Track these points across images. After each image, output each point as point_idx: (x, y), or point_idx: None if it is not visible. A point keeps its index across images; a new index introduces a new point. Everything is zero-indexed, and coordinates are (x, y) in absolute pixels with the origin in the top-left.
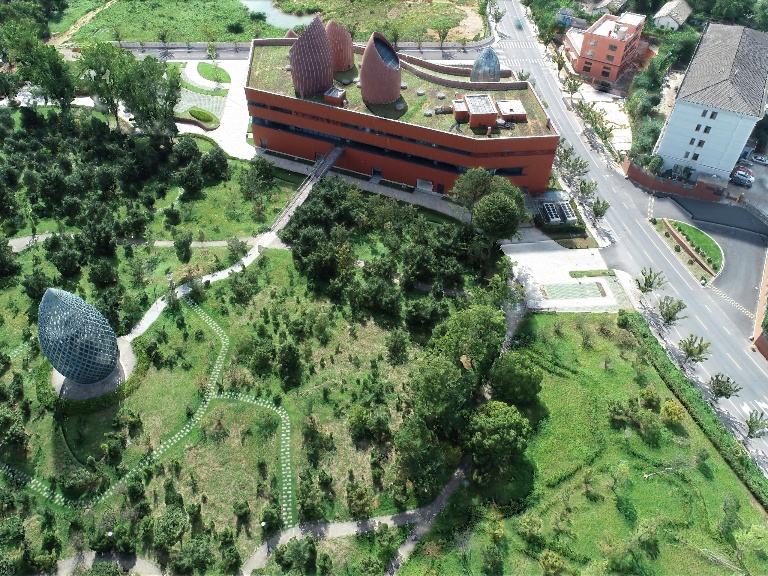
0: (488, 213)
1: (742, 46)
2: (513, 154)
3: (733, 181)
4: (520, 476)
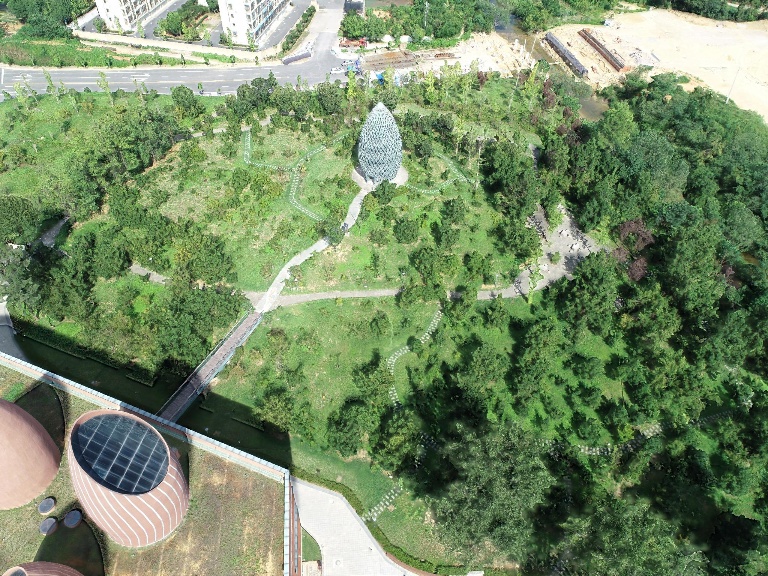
0: (22, 200)
1: None
2: None
3: None
4: None
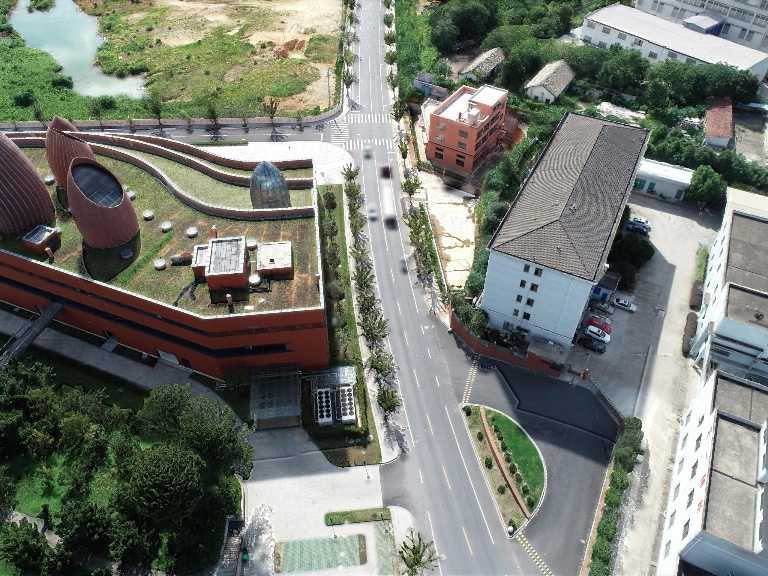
0: (140, 490)
1: (593, 158)
2: (264, 330)
3: (581, 342)
4: None
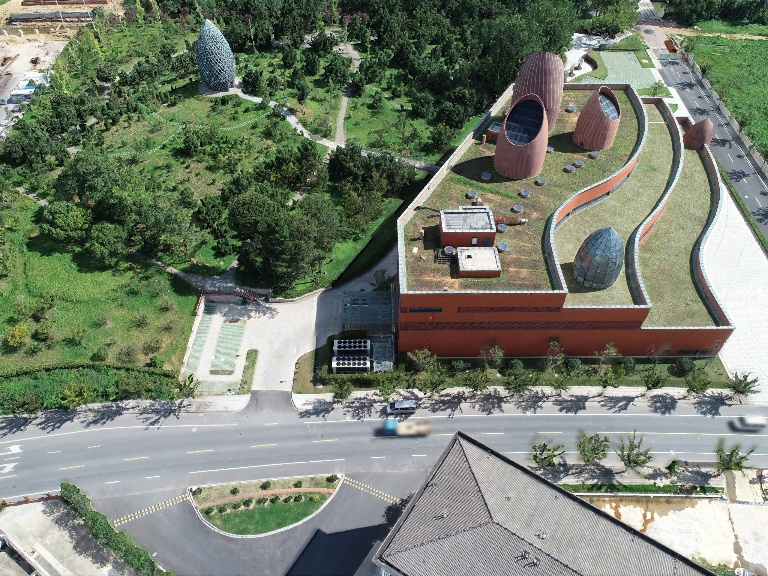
0: None
1: None
2: None
3: None
4: (43, 247)
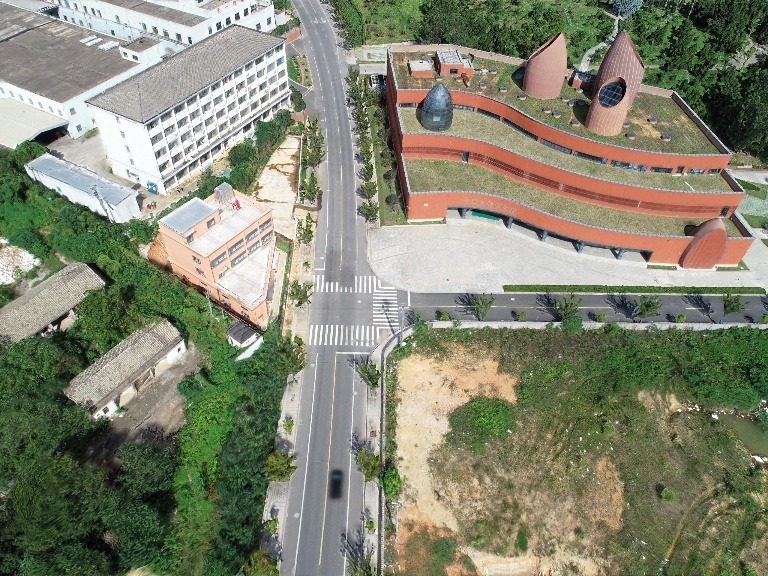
0: None
1: None
2: None
3: None
4: None
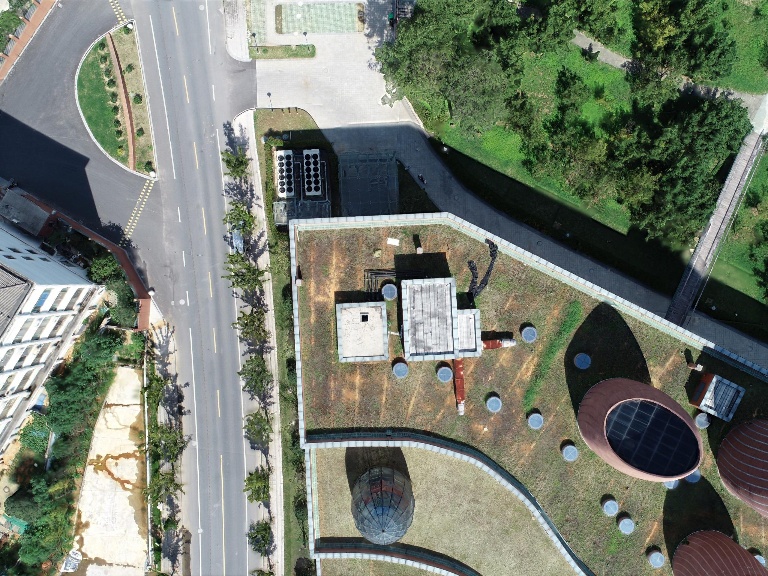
0: None
1: None
2: None
3: None
4: None
